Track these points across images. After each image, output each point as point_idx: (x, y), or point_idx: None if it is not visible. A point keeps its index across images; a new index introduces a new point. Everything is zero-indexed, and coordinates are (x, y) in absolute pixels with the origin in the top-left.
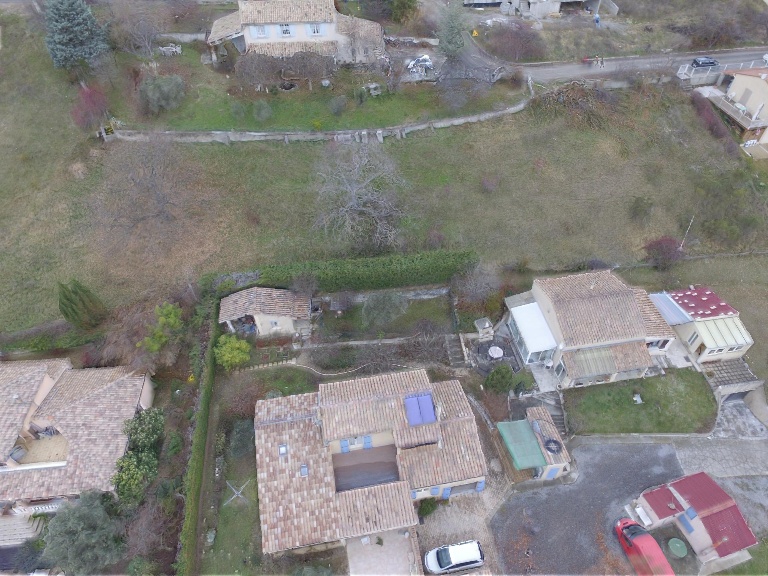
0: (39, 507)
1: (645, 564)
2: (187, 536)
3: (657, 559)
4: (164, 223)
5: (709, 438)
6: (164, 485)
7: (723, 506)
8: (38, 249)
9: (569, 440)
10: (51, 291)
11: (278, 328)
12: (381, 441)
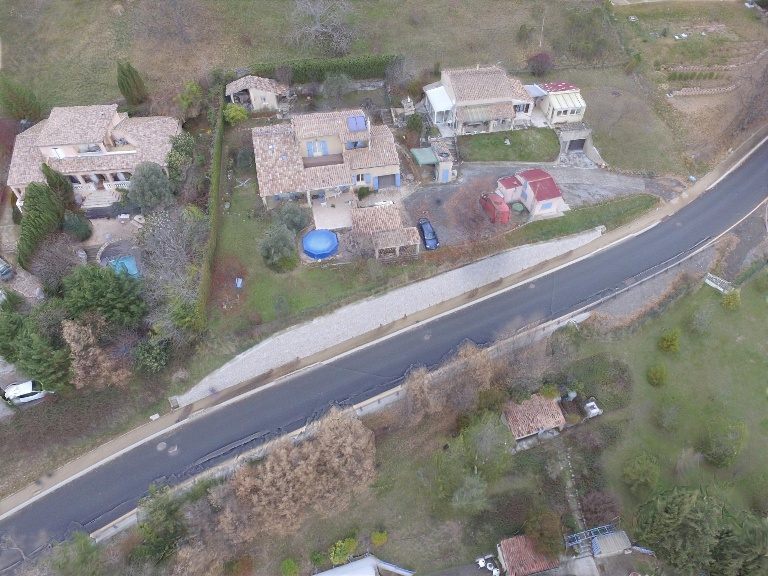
0: (119, 185)
1: (492, 205)
2: (213, 192)
3: None
4: (182, 44)
5: (554, 166)
6: None
7: (544, 178)
8: (94, 60)
9: (460, 164)
10: (107, 85)
11: (266, 104)
12: (333, 149)
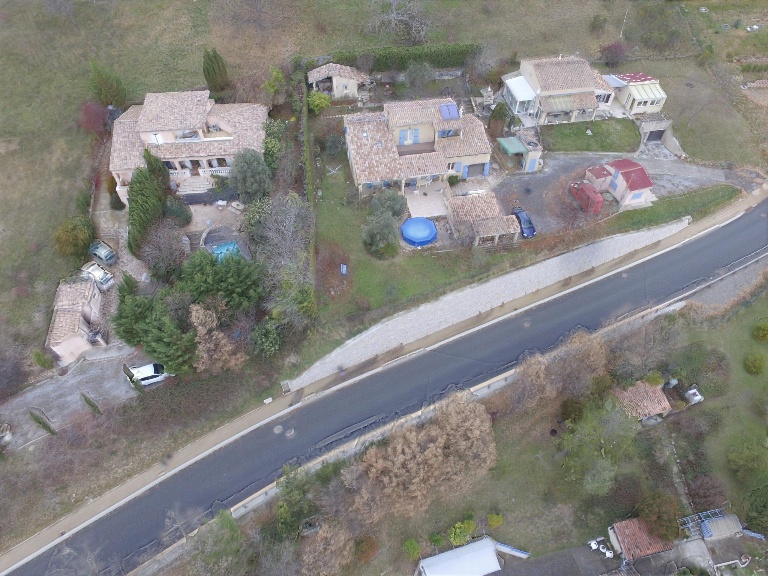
0: (214, 171)
1: (586, 195)
2: (310, 179)
3: None
4: (258, 31)
5: (635, 157)
6: None
7: (635, 168)
8: (172, 46)
9: (543, 154)
10: (186, 72)
11: (347, 92)
12: (424, 137)
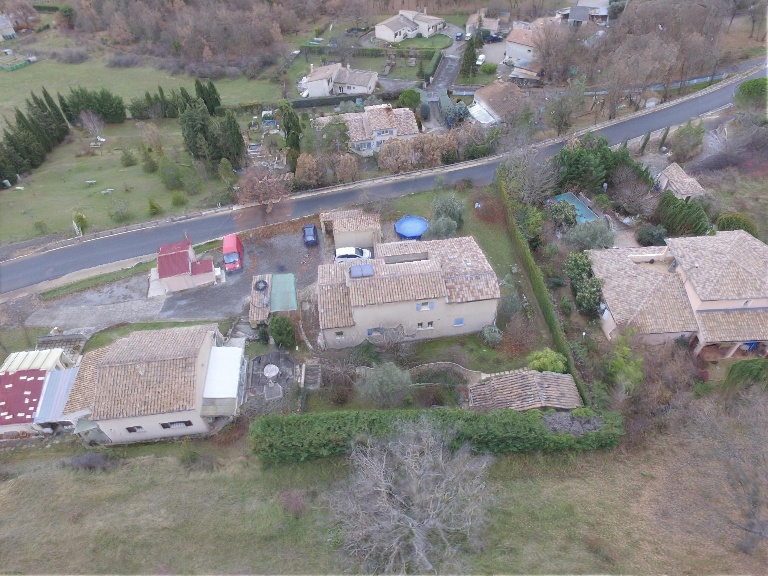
0: None
1: None
2: (524, 247)
3: None
4: None
5: None
6: (558, 278)
7: None
8: None
9: None
10: None
11: None
12: None
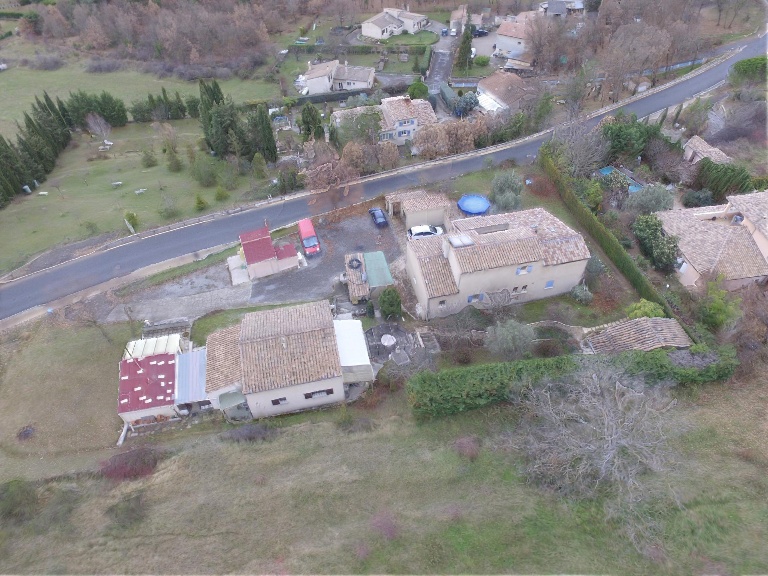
0: None
1: None
2: None
3: None
4: None
5: None
6: None
7: None
8: None
9: None
10: None
11: None
12: None
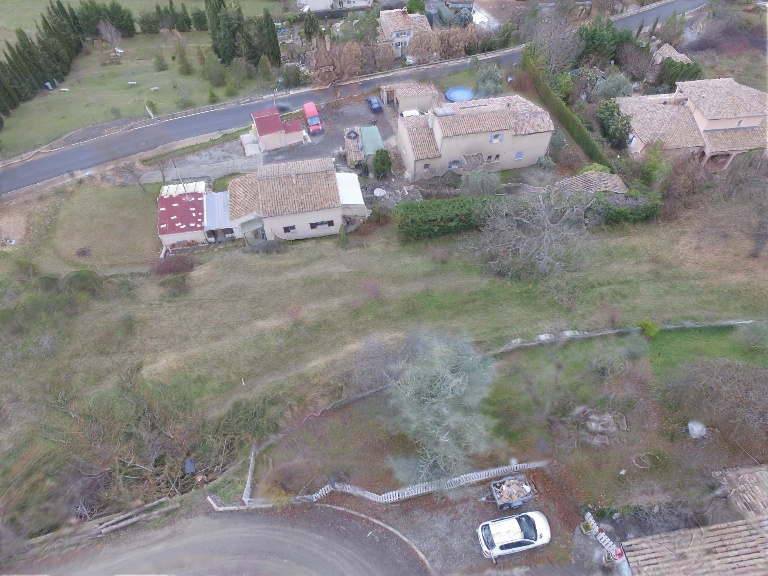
0: None
1: None
2: None
3: (310, 107)
4: None
5: None
6: None
7: None
8: None
9: None
10: None
11: None
12: None
